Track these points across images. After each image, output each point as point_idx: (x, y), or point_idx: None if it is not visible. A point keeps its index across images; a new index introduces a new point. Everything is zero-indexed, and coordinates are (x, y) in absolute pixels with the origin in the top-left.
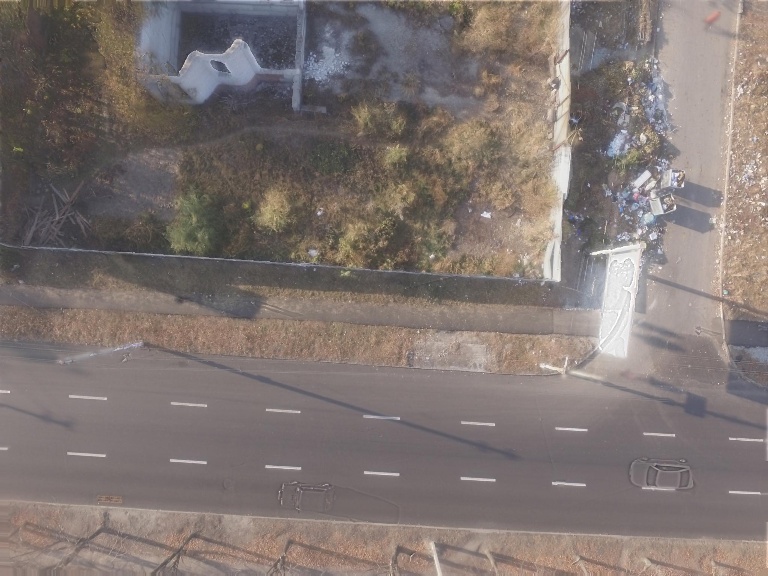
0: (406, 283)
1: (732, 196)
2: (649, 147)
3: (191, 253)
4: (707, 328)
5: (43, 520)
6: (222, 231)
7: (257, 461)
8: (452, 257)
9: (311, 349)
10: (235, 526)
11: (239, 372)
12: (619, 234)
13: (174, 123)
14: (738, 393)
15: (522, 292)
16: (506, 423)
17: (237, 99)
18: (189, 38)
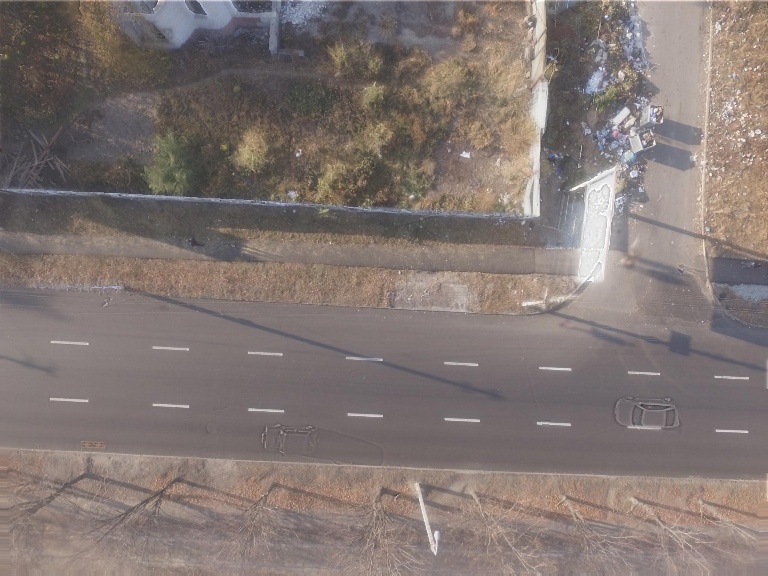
0: (386, 224)
1: (712, 133)
2: (627, 84)
3: (170, 195)
4: (690, 266)
5: (26, 466)
6: (201, 174)
7: (240, 404)
8: (432, 197)
9: (292, 291)
10: (219, 470)
11: (220, 315)
12: (599, 172)
13: (151, 66)
14: (723, 331)
15: (503, 232)
16: (489, 363)
17: (214, 42)
18: None
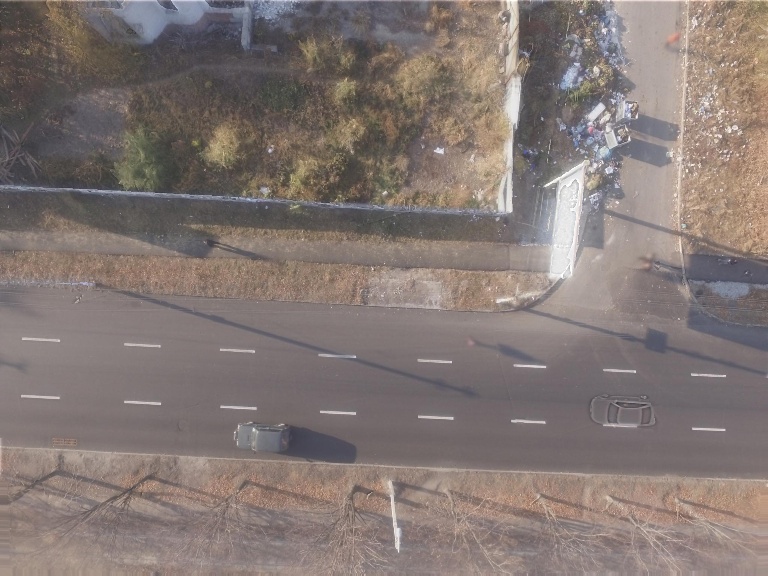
0: (359, 220)
1: (689, 129)
2: (603, 80)
3: (140, 191)
4: (666, 263)
5: None
6: (173, 170)
7: (212, 401)
8: (405, 194)
9: (264, 288)
10: (191, 467)
11: (192, 312)
12: None
13: (122, 61)
14: (699, 328)
15: (477, 228)
16: (463, 361)
17: (185, 37)
18: None
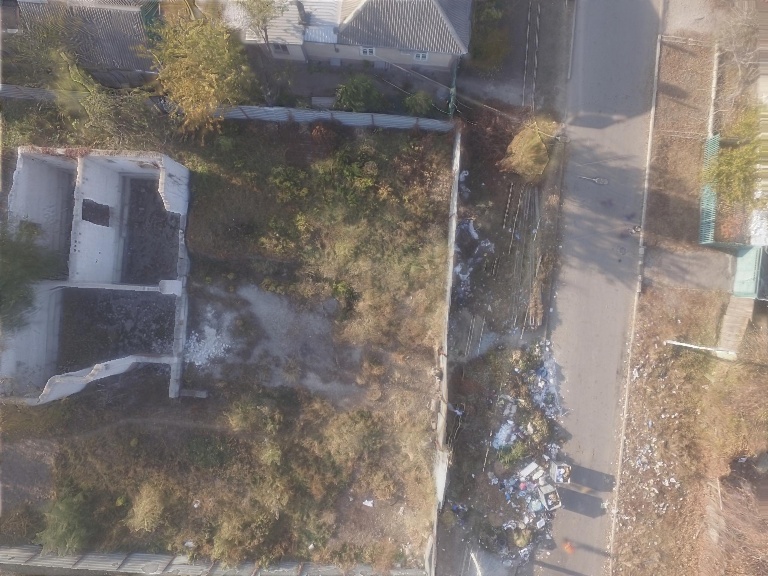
0: (285, 573)
1: (624, 482)
2: (537, 437)
3: None
4: None
5: None
6: (98, 524)
7: None
8: (332, 546)
9: None
10: None
11: None
12: (505, 523)
13: None
14: None
15: None
16: None
17: (112, 393)
18: (72, 311)
